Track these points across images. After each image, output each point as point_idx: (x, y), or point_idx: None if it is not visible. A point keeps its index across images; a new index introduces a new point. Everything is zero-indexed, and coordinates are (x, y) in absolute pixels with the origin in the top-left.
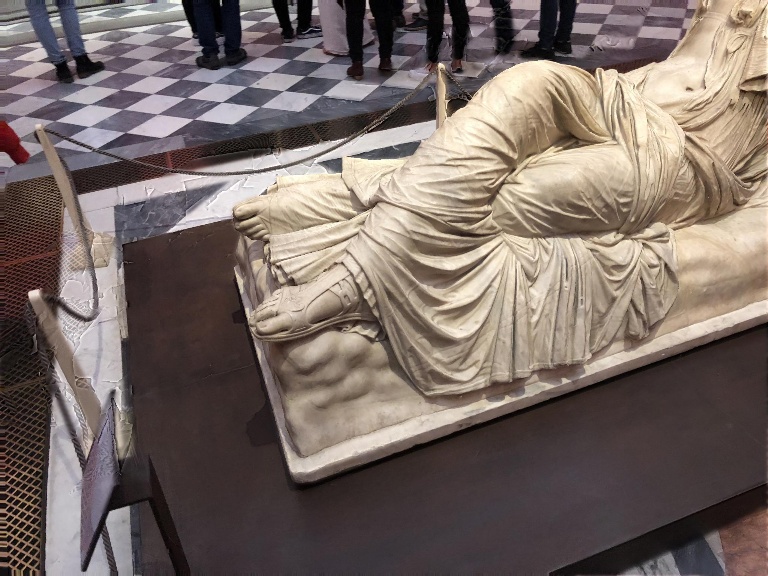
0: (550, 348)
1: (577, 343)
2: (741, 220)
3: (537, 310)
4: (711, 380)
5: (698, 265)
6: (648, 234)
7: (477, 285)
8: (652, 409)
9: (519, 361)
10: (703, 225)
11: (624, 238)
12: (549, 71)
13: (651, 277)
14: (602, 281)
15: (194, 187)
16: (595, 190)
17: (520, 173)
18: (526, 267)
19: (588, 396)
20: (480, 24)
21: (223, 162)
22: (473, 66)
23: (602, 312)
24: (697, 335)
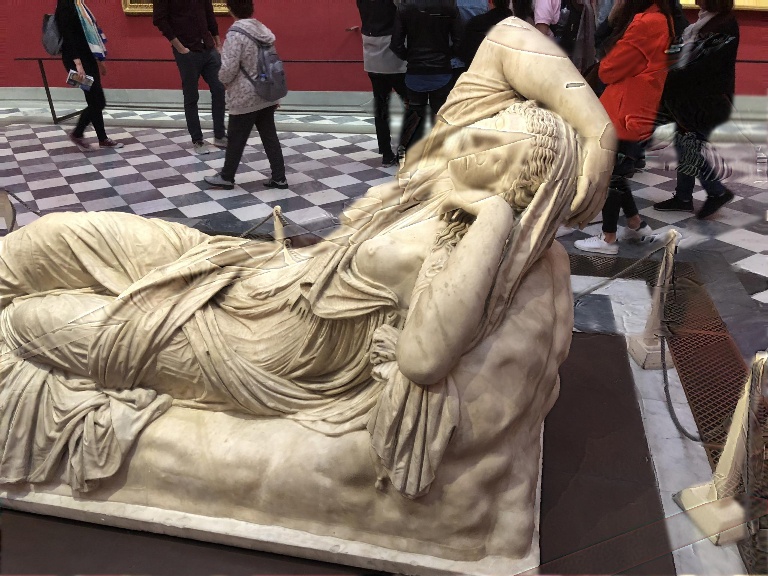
0: None
1: None
2: (262, 427)
3: None
4: (117, 567)
5: (164, 447)
6: (120, 395)
7: None
8: (40, 560)
9: None
10: (230, 416)
11: (99, 389)
12: (88, 222)
13: (87, 433)
14: None
15: None
16: (43, 331)
17: (30, 298)
18: None
19: (31, 523)
20: None
21: None
22: None
23: (40, 446)
24: (141, 517)
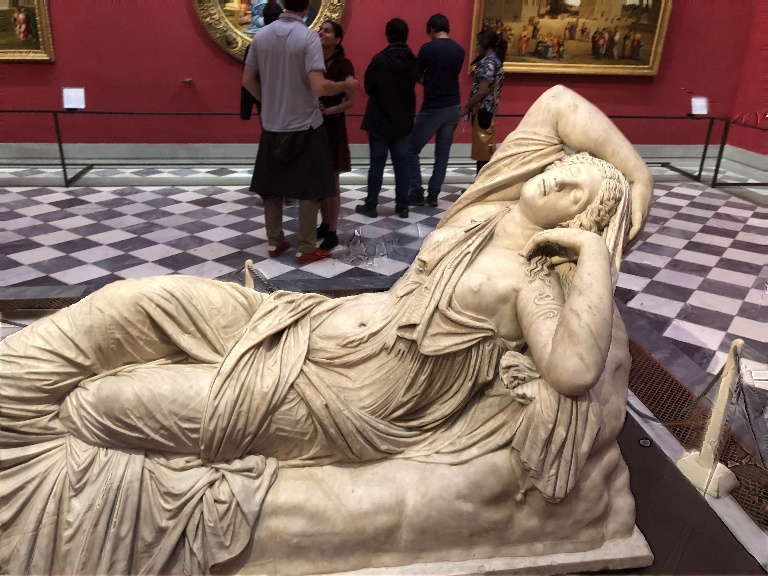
0: (75, 568)
1: (103, 569)
2: (379, 471)
3: (75, 523)
4: None
5: (291, 511)
6: (233, 466)
7: (13, 483)
8: None
9: (29, 575)
10: (339, 468)
11: (205, 465)
12: (161, 288)
13: (211, 513)
14: (151, 506)
15: (3, 334)
16: (147, 410)
17: (100, 379)
18: (70, 475)
19: None
20: (432, 226)
21: (41, 316)
22: (394, 264)
23: (148, 540)
24: None
